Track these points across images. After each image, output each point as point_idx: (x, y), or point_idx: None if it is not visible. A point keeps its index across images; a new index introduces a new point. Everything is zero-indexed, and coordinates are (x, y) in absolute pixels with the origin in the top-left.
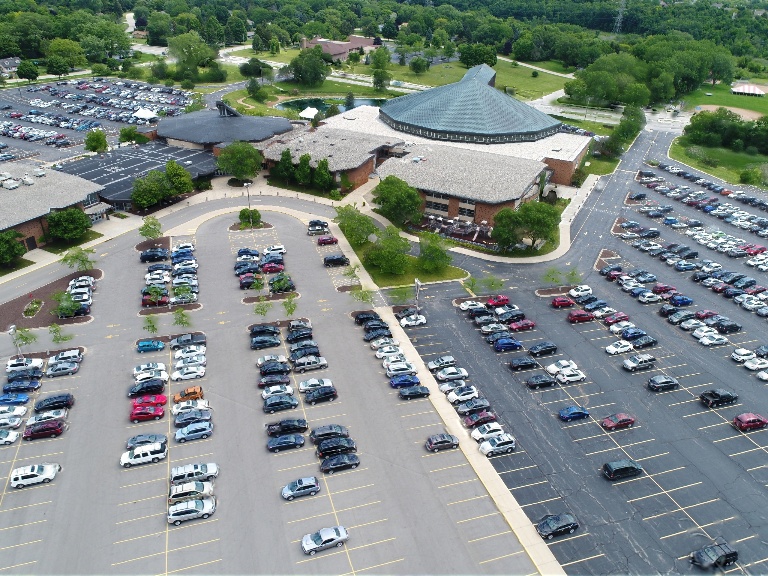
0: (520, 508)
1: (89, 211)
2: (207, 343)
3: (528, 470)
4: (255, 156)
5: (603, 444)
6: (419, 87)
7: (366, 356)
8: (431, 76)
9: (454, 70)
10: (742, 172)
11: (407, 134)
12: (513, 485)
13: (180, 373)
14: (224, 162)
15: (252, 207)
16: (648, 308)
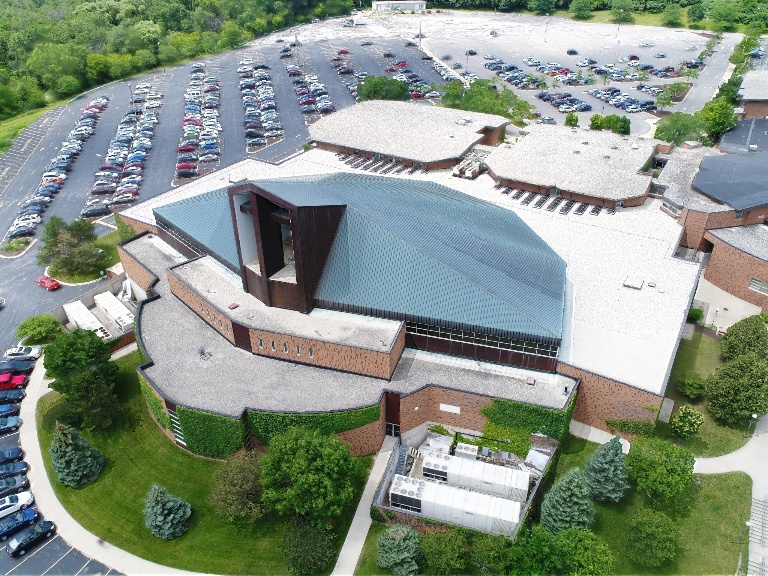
0: None
1: (739, 108)
2: None
3: None
4: None
5: (401, 68)
6: None
7: None
8: None
9: None
10: None
11: None
12: None
13: None
14: None
15: None
16: None
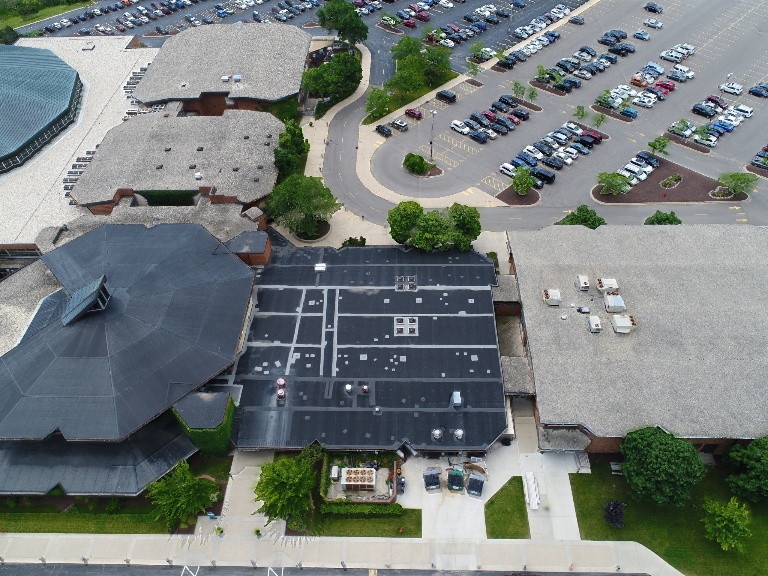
0: (587, 2)
1: None
2: None
3: (565, 5)
4: None
5: None
6: None
7: (539, 55)
8: None
9: None
10: None
11: (47, 148)
12: (577, 6)
13: (632, 90)
14: None
15: (375, 187)
16: (387, 6)
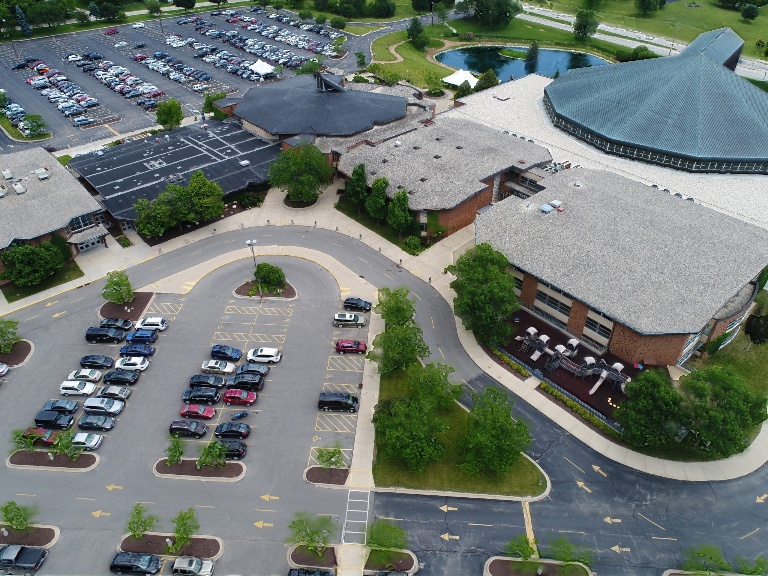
0: None
1: (75, 238)
2: (46, 563)
3: None
4: (318, 169)
5: None
6: (640, 35)
7: None
8: (656, 24)
9: (700, 9)
10: None
11: (569, 136)
12: None
13: None
14: (276, 174)
15: (290, 250)
16: None
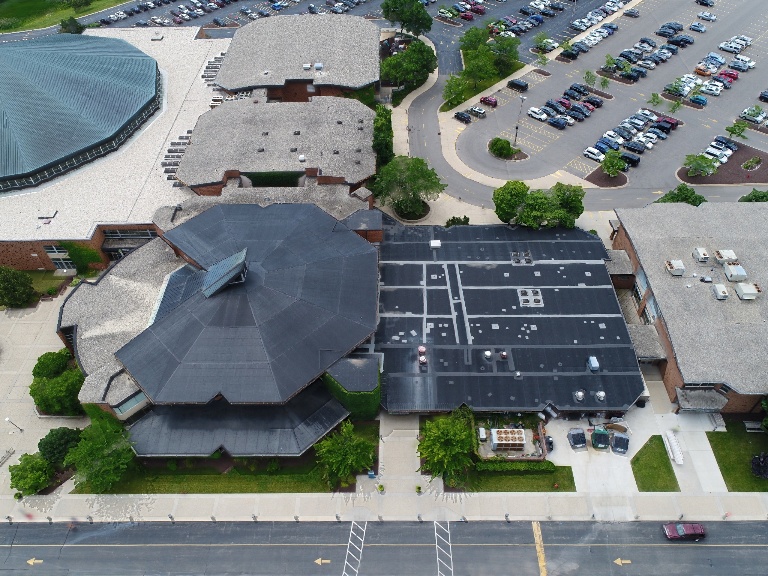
0: None
1: None
2: None
3: None
4: None
5: None
6: None
7: (600, 46)
8: None
9: None
10: (67, 5)
11: (138, 134)
12: None
13: (698, 79)
14: None
15: (465, 170)
16: None
